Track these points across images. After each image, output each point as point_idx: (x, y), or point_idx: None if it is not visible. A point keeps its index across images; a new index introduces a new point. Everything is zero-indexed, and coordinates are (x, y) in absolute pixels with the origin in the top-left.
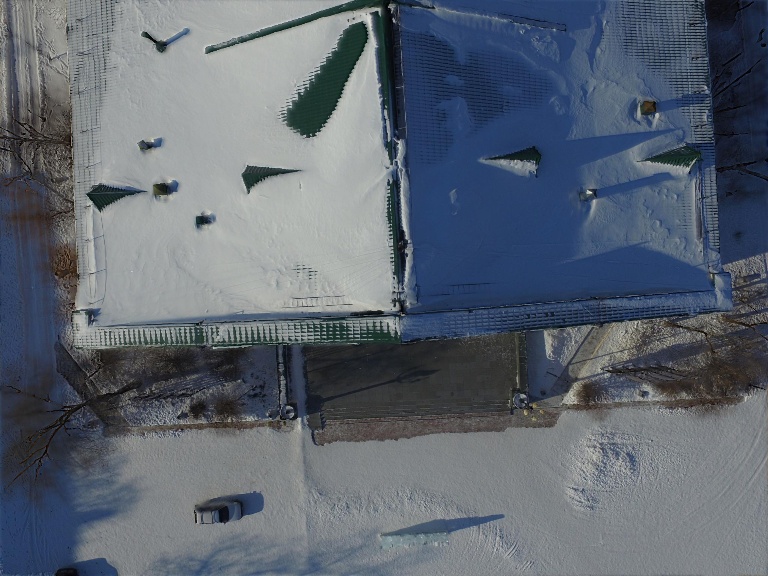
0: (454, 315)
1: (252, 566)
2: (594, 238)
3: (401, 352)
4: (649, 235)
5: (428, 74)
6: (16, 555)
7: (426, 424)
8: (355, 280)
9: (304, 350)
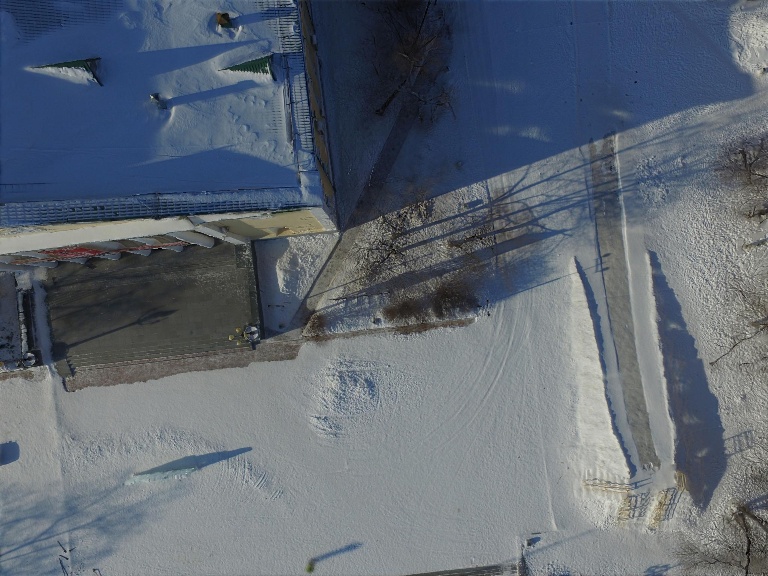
0: None
1: (11, 514)
2: (174, 143)
3: (140, 295)
4: (236, 139)
5: None
6: None
7: (173, 364)
8: None
9: (47, 299)
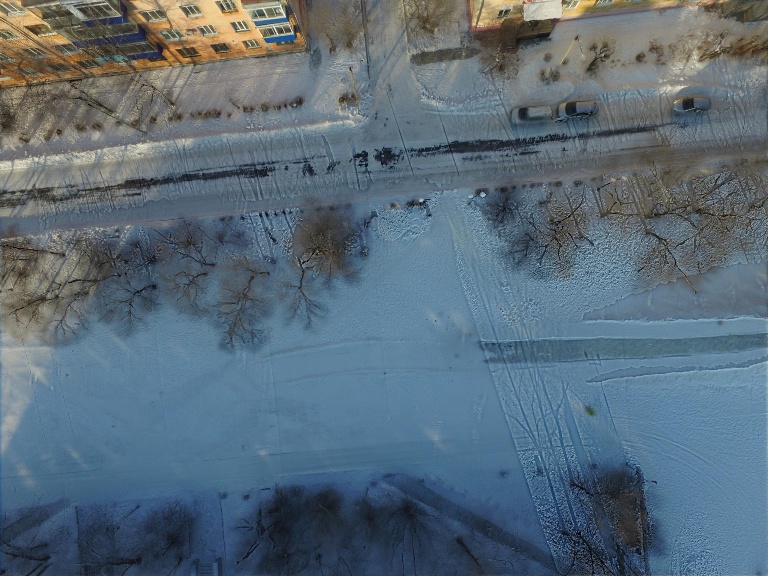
0: None
1: None
2: None
3: None
4: None
5: None
6: None
7: None
8: None
9: None
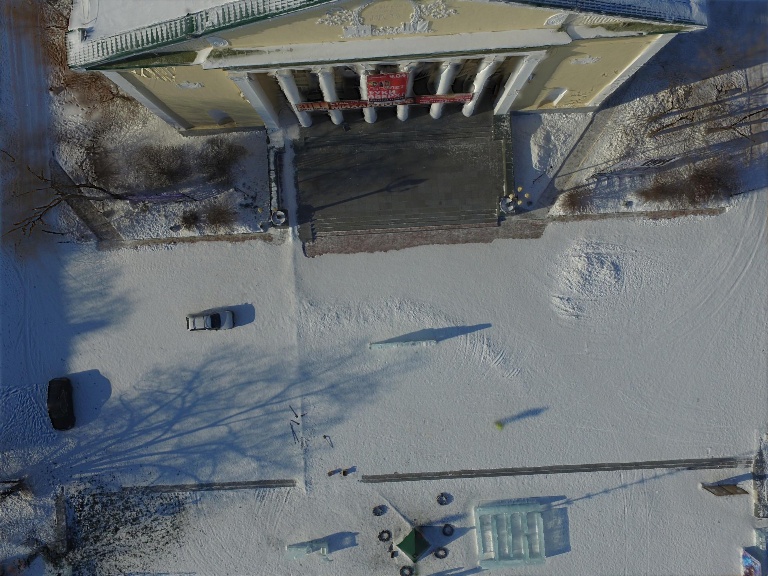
0: None
1: (243, 376)
2: None
3: (390, 162)
4: None
5: None
6: (10, 366)
7: (415, 236)
8: None
9: (295, 160)
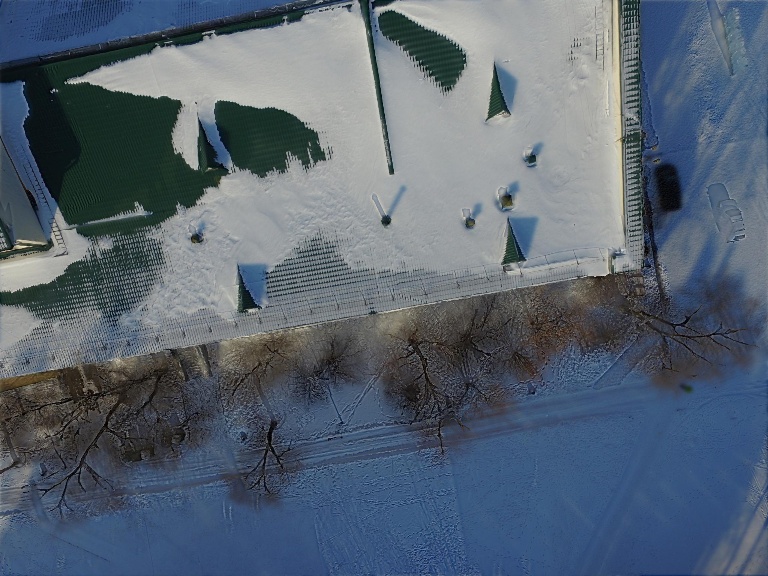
0: None
1: None
2: None
3: None
4: None
5: None
6: None
7: None
8: None
9: None
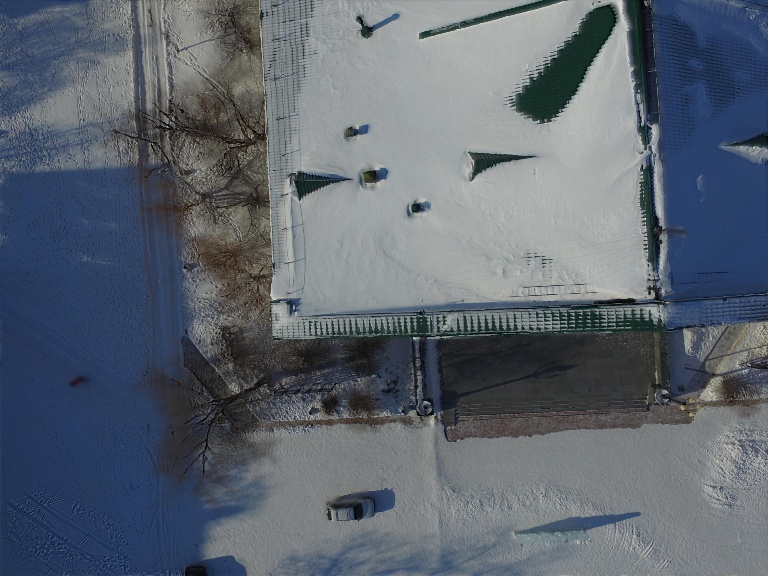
0: (710, 303)
1: (383, 564)
2: None
3: (538, 347)
4: None
5: (673, 59)
6: (143, 552)
7: (561, 420)
8: (601, 268)
9: (439, 345)
